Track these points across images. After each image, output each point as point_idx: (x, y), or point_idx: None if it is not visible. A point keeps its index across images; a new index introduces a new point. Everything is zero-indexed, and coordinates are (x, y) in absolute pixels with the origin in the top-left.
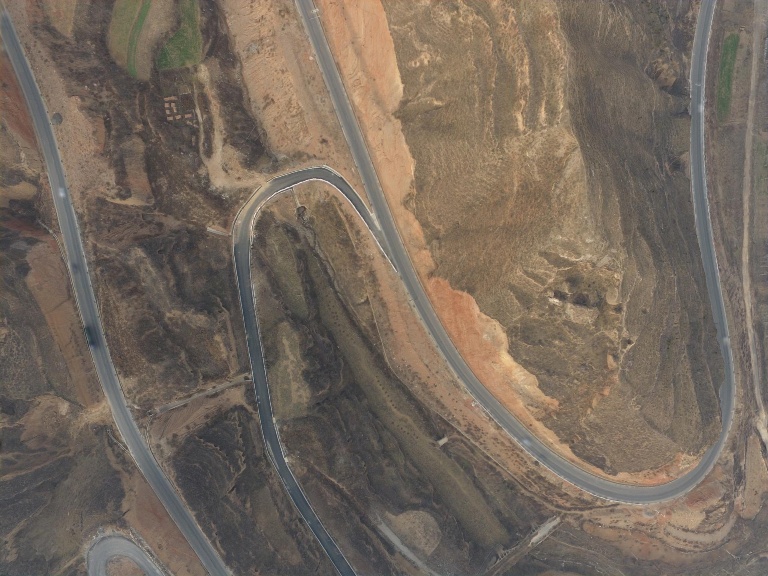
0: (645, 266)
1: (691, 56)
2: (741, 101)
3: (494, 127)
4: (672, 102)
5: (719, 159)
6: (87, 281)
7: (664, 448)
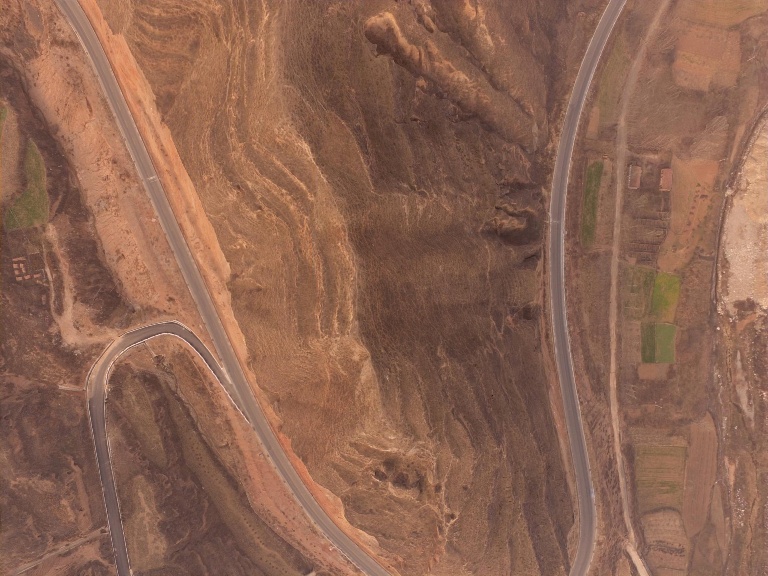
0: (462, 446)
1: (551, 189)
2: (606, 228)
3: (298, 326)
4: (514, 254)
5: (585, 286)
6: None
7: None
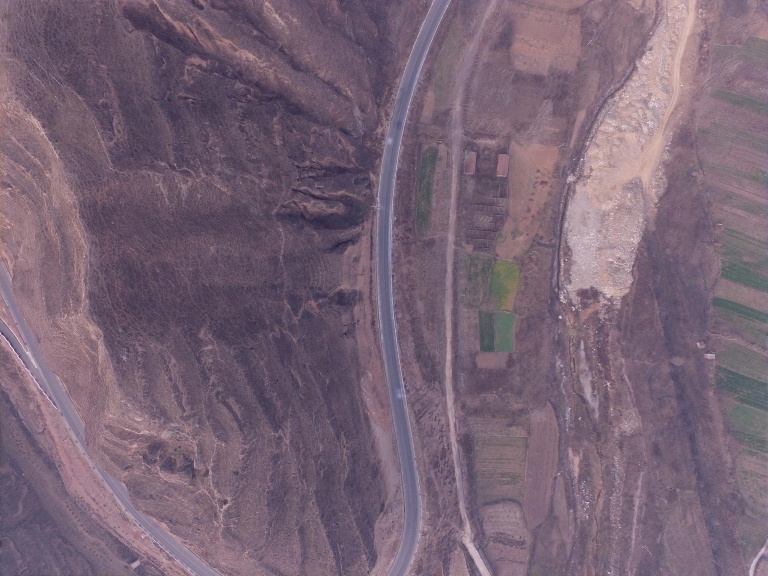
0: (230, 430)
1: (380, 174)
2: (441, 214)
3: (46, 305)
4: (319, 238)
5: (420, 273)
6: None
7: None
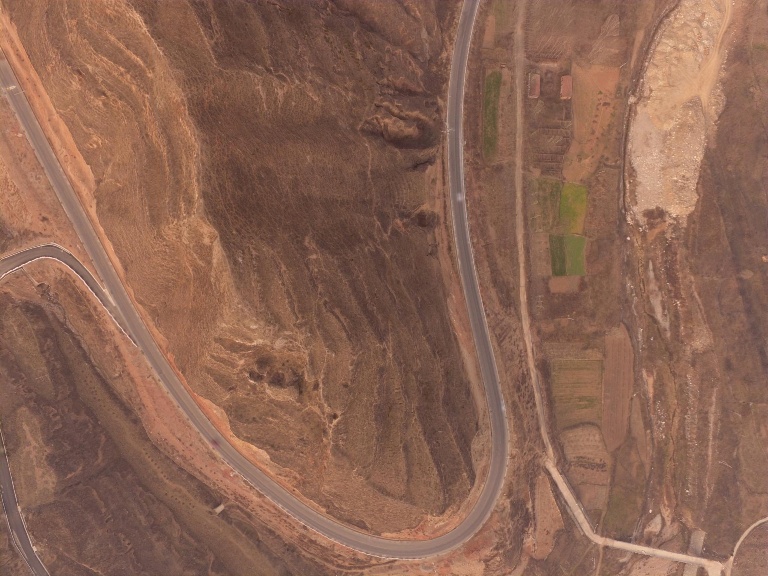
0: (338, 340)
1: (447, 98)
2: (508, 139)
3: (149, 215)
4: (401, 156)
5: (489, 199)
6: None
7: (405, 512)
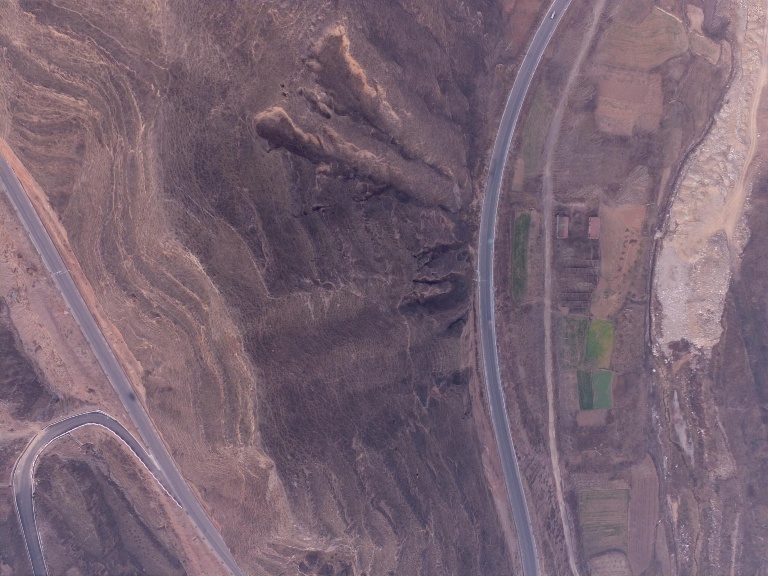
0: (385, 534)
1: (478, 246)
2: (537, 280)
3: (204, 433)
4: (437, 324)
5: (519, 339)
6: None
7: None
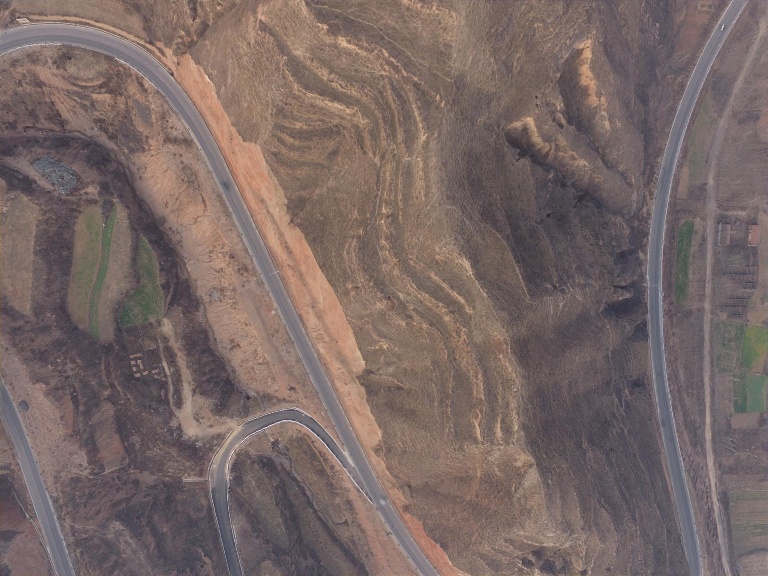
0: (607, 531)
1: (647, 252)
2: (698, 285)
3: (454, 431)
4: (629, 328)
5: (679, 343)
6: (68, 564)
7: None
